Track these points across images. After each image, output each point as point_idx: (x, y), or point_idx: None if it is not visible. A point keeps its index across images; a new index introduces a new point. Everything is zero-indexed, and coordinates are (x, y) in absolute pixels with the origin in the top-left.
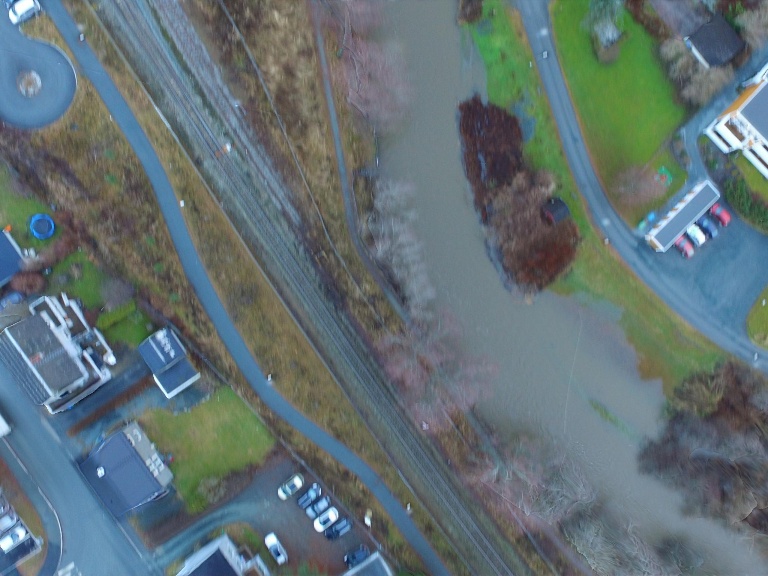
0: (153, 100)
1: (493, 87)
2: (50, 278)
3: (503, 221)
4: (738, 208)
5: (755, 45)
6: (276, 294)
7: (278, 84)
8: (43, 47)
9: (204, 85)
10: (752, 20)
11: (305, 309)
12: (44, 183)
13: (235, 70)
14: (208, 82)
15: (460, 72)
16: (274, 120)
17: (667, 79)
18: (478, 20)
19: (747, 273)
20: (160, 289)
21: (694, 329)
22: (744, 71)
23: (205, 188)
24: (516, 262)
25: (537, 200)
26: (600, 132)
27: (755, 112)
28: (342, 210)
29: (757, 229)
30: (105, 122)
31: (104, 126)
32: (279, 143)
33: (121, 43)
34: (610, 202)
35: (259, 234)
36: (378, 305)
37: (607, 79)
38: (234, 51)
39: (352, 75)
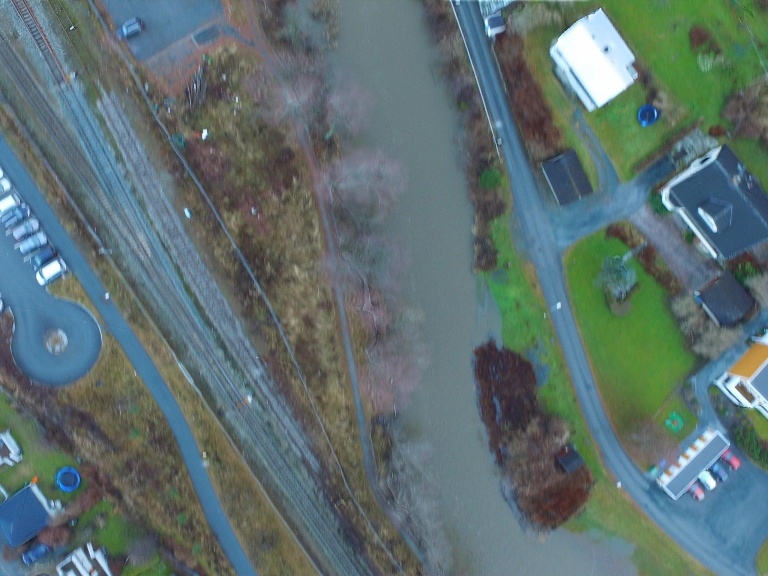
0: (176, 356)
1: (508, 333)
2: (76, 528)
3: (518, 467)
4: (748, 453)
5: (764, 305)
6: (296, 541)
7: (298, 335)
8: (69, 306)
9: (226, 338)
10: (761, 283)
11: (324, 553)
12: (70, 438)
13: (256, 323)
14: (230, 335)
15: (475, 318)
16: (294, 371)
17: (678, 330)
18: (493, 269)
19: (756, 513)
20: (183, 538)
21: (705, 567)
22: (753, 324)
23: (227, 439)
24: (530, 505)
25: (551, 449)
26: (612, 379)
27: (765, 383)
28: (360, 458)
29: (766, 472)
30: (130, 377)
31: (129, 381)
32: (299, 394)
33: (145, 300)
34: (622, 447)
35: (279, 481)
36: (396, 550)
37: (619, 329)
38: (255, 305)
39: (370, 325)
